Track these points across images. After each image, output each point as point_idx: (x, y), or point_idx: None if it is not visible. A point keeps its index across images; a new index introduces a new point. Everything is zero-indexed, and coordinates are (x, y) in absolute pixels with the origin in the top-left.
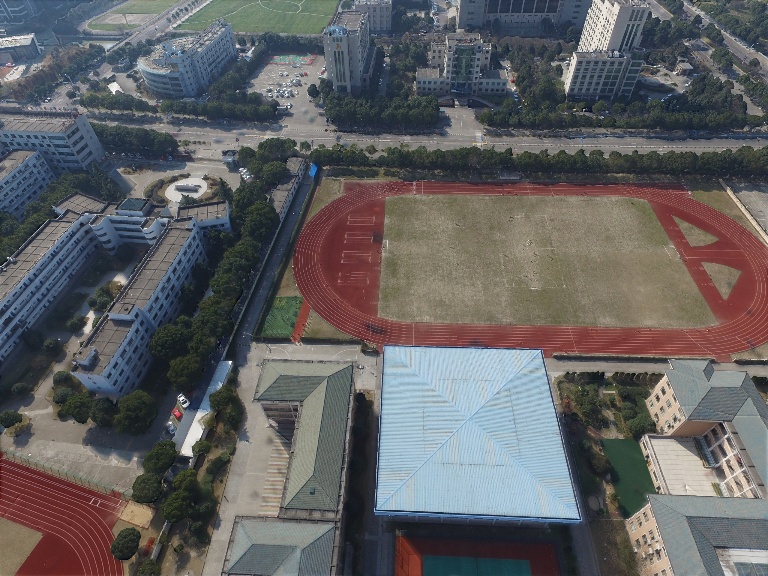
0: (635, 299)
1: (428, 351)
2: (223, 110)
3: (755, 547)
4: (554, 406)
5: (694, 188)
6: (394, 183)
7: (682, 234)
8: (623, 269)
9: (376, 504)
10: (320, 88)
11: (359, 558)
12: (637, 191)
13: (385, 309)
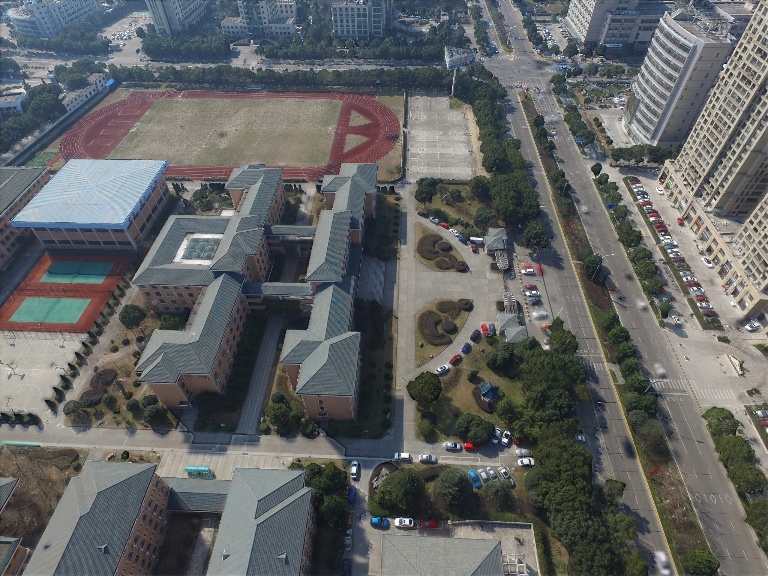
0: (284, 152)
1: (95, 161)
2: (63, 45)
3: (209, 232)
4: (151, 183)
5: (383, 94)
6: (168, 92)
7: (349, 119)
8: (290, 137)
9: (12, 219)
10: (147, 31)
11: (16, 262)
12: (340, 96)
13: (111, 158)
